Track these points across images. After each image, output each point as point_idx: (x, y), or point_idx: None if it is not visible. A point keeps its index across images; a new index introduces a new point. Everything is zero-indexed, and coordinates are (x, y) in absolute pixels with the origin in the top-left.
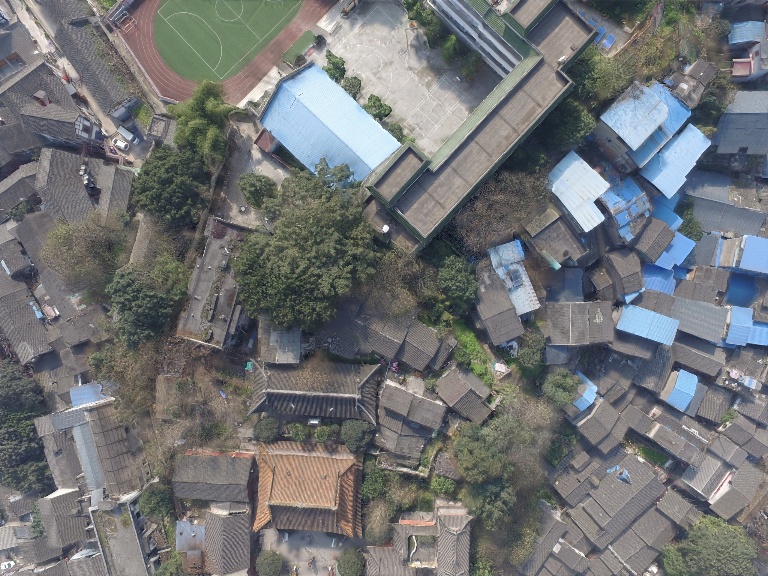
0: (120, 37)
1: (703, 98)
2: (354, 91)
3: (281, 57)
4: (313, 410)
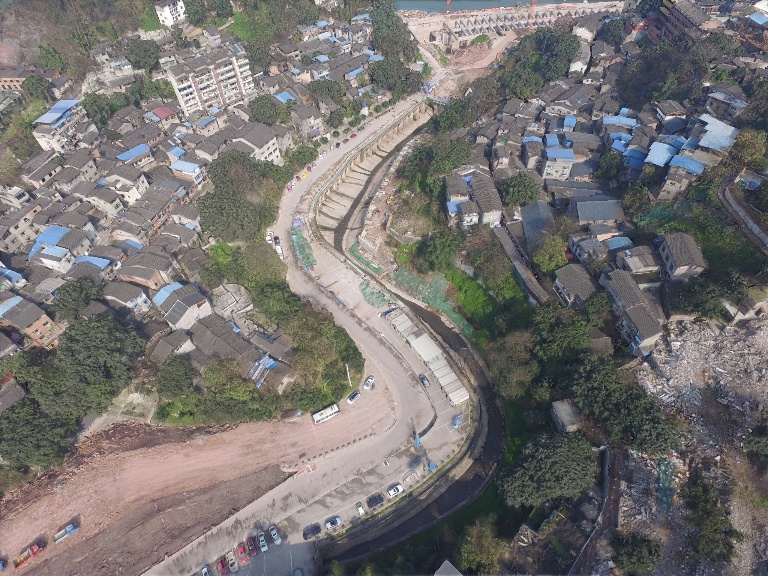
0: None
1: None
2: None
3: None
4: None
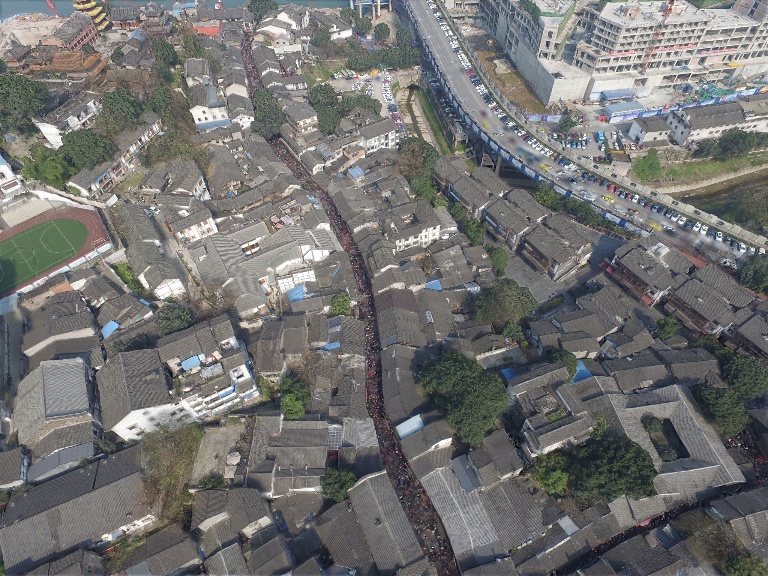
0: (105, 233)
1: None
2: None
3: (4, 232)
4: None
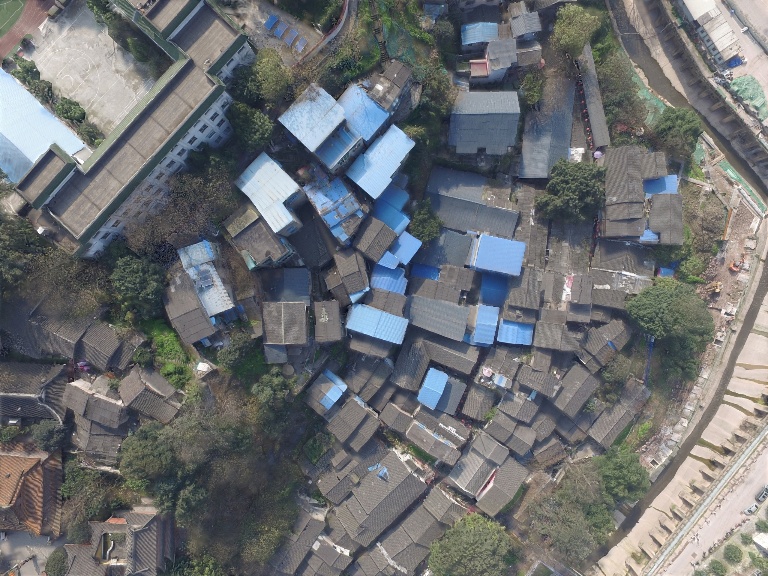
0: None
1: (421, 99)
2: (41, 94)
3: None
4: (4, 410)
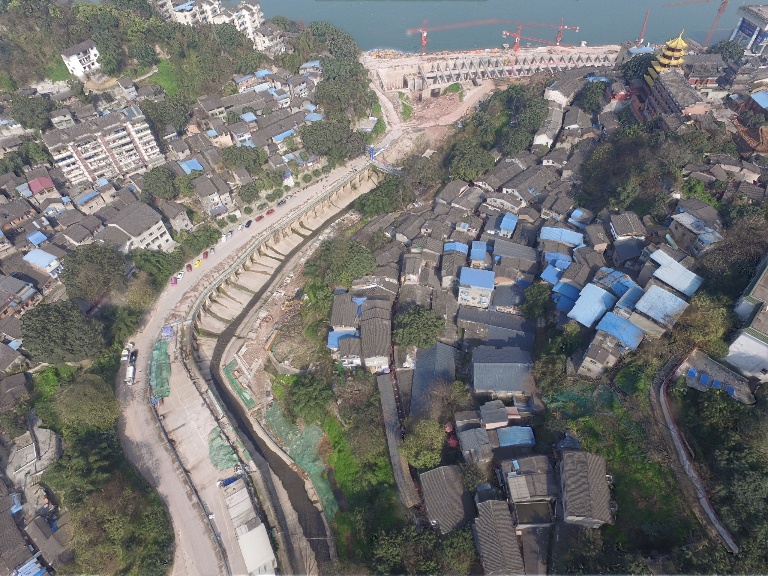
0: None
1: None
2: None
3: None
4: None
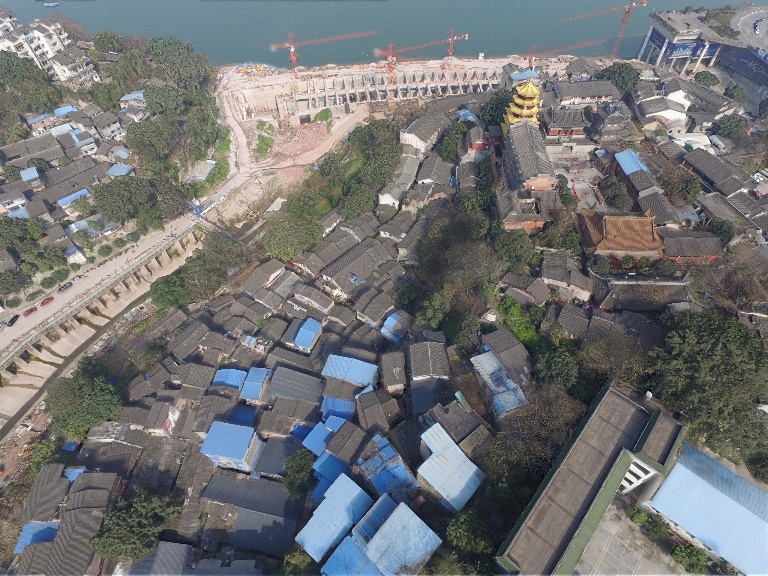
0: None
1: None
2: (729, 572)
3: None
4: None
